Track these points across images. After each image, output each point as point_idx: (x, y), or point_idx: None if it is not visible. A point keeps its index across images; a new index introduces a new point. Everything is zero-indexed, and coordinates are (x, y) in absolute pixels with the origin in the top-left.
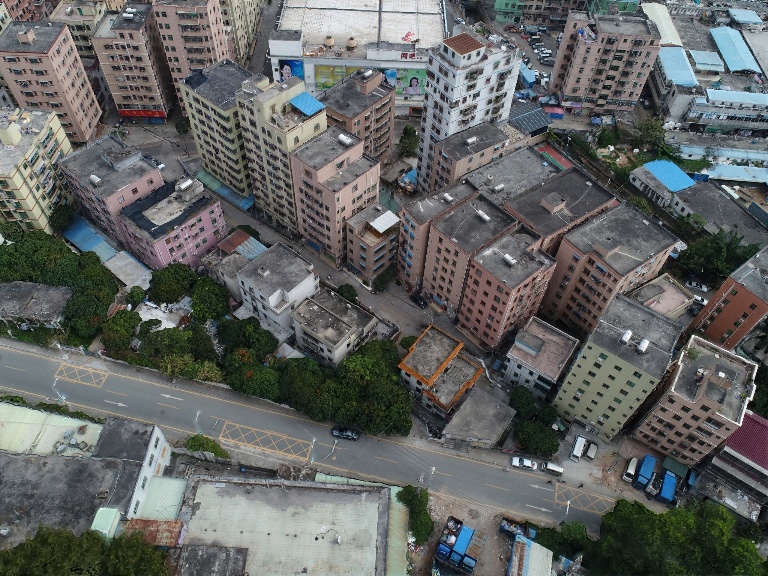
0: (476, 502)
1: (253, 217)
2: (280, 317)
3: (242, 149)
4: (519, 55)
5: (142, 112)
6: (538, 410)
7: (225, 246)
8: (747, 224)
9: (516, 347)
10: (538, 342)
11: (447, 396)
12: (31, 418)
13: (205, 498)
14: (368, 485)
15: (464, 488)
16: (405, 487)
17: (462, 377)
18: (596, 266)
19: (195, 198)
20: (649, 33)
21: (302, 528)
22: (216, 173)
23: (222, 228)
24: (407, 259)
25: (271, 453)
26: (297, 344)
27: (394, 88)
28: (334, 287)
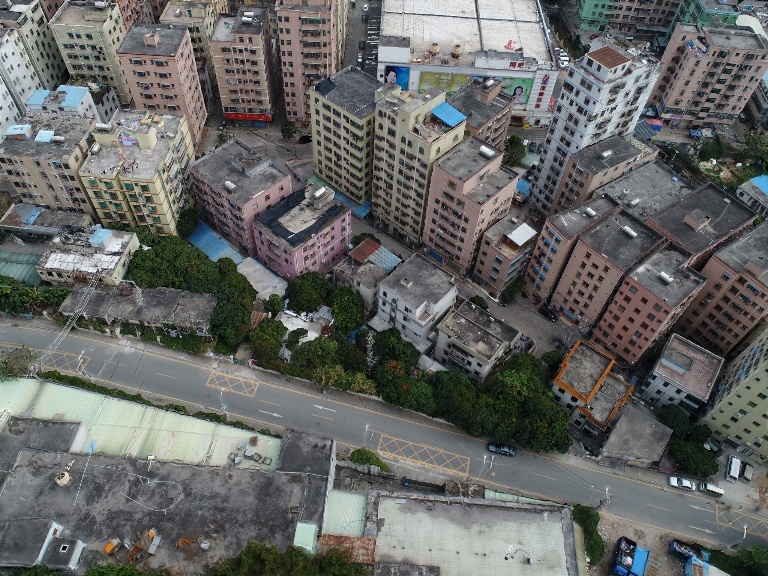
0: (640, 522)
1: (370, 225)
2: (423, 329)
3: (367, 157)
4: (658, 69)
5: (248, 115)
6: (691, 429)
7: (357, 255)
8: None
9: (662, 365)
10: (686, 360)
11: (601, 413)
12: (200, 428)
13: (388, 514)
14: (540, 503)
15: (626, 507)
16: (576, 506)
17: (617, 395)
18: (747, 285)
19: (326, 206)
20: (761, 47)
21: (490, 547)
22: (331, 179)
23: (348, 236)
24: (541, 272)
25: (431, 468)
26: (434, 356)
27: (514, 98)
28: (463, 298)
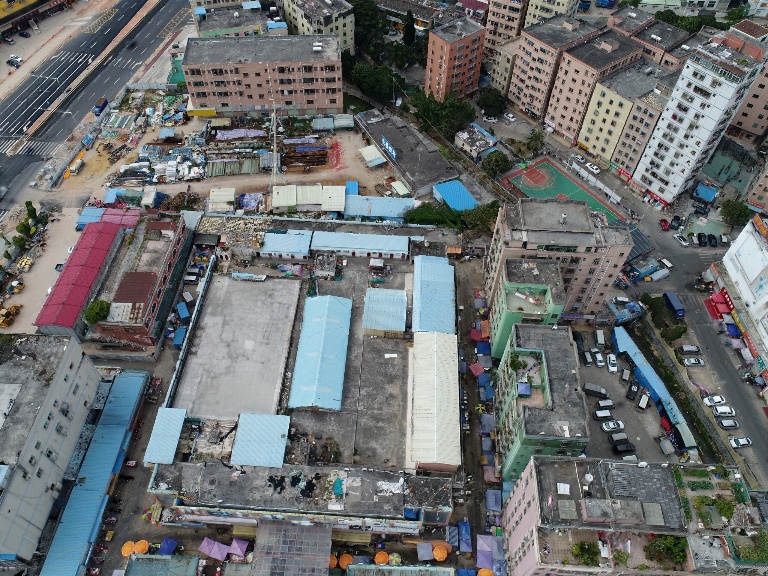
0: None
1: None
2: None
3: None
4: None
5: None
6: None
7: None
8: (400, 152)
9: None
10: None
11: None
12: None
13: None
14: None
15: None
16: (639, 2)
17: None
18: None
19: None
20: None
21: None
22: None
23: None
24: None
25: None
26: None
27: None
28: None
